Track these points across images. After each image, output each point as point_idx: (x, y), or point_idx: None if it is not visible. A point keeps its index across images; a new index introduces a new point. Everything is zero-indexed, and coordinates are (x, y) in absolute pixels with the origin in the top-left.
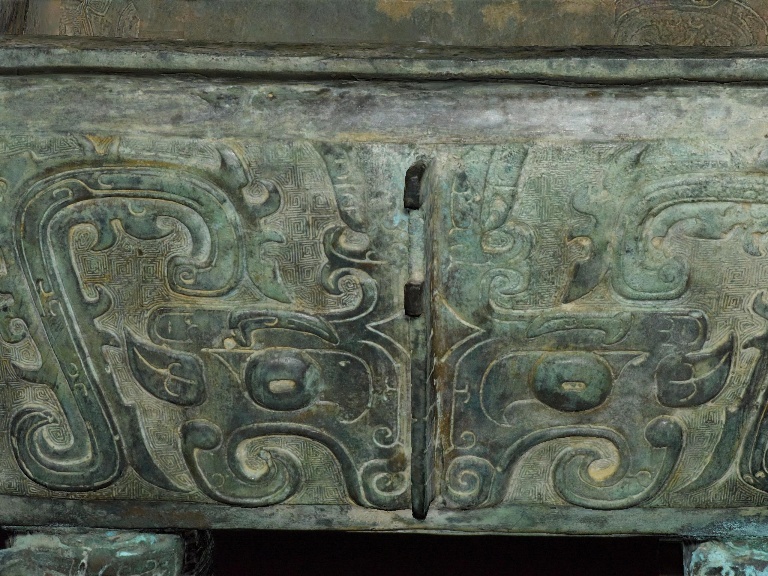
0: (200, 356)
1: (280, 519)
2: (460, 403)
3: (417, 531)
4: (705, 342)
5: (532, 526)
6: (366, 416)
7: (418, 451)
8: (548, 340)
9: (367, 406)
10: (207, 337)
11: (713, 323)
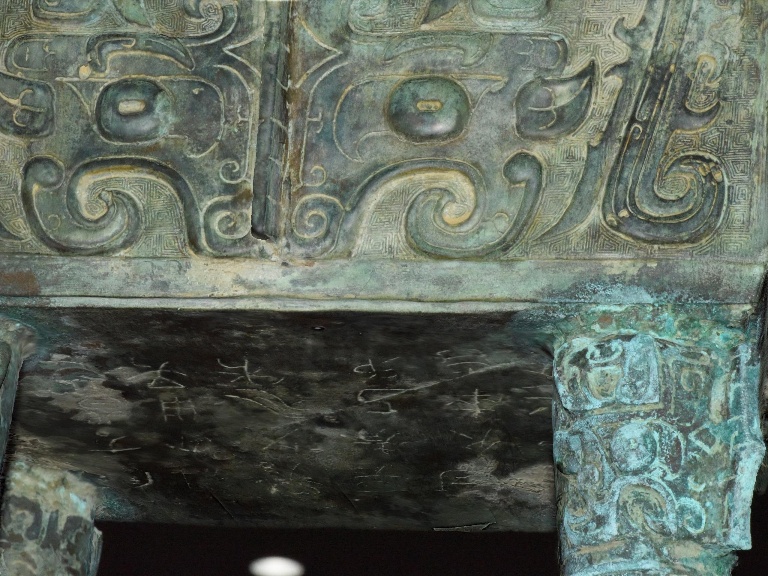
0: (53, 85)
1: (114, 281)
2: (312, 133)
3: (259, 306)
4: (565, 68)
5: (381, 290)
6: (215, 150)
7: (262, 156)
8: (405, 63)
9: (217, 139)
10: (63, 65)
11: (574, 49)
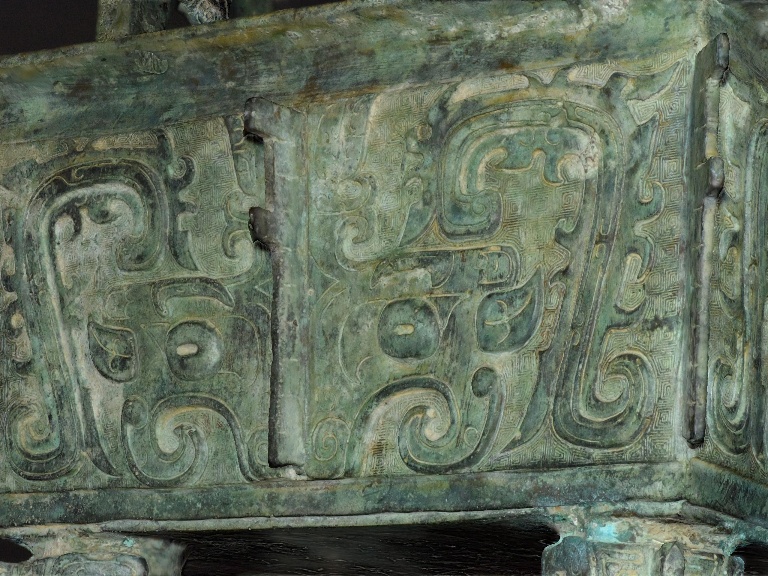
0: None
1: None
2: None
3: None
4: None
5: None
6: None
7: None
8: None
9: None
10: None
11: None
